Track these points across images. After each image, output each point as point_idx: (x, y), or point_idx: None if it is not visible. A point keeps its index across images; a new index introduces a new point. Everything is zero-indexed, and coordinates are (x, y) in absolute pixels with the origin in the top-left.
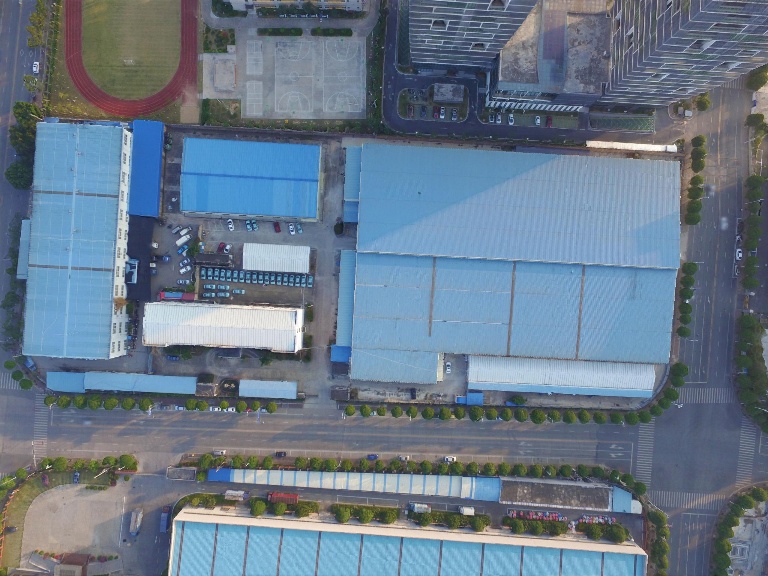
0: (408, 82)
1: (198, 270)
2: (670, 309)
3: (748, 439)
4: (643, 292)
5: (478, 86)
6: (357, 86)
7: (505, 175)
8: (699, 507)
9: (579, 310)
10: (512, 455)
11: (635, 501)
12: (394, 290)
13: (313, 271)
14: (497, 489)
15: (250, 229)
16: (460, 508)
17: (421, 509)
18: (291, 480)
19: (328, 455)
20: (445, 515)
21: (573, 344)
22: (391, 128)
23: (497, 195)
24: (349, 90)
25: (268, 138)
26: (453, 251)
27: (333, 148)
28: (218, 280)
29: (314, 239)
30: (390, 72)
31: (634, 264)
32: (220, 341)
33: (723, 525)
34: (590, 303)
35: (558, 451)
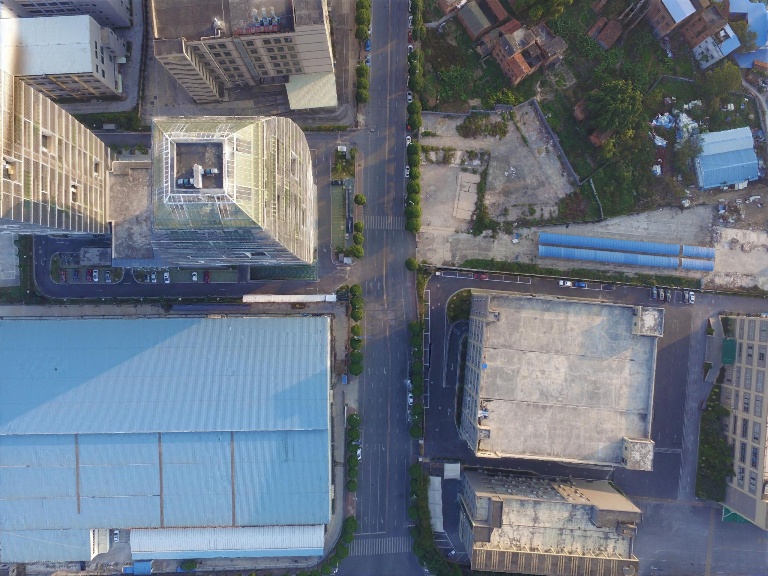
0: (60, 246)
1: None
2: (325, 469)
3: None
4: (296, 454)
5: None
6: (9, 252)
7: (145, 344)
8: None
9: (231, 476)
10: None
11: None
12: (37, 469)
13: None
14: None
15: None
16: None
17: None
18: None
19: None
20: None
21: (228, 511)
22: (45, 294)
23: (137, 366)
24: (1, 257)
25: None
26: (91, 428)
27: None
28: None
29: None
30: (40, 237)
31: (280, 428)
32: None
33: None
34: (242, 469)
35: None
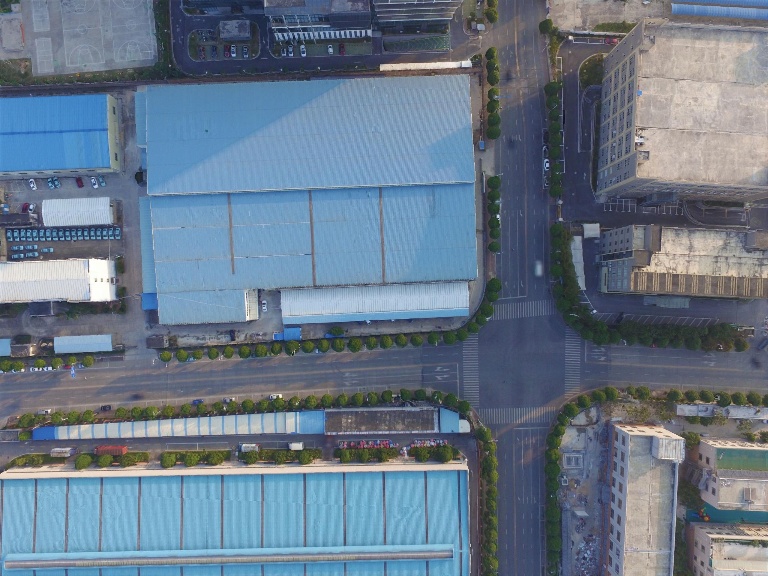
0: (196, 23)
1: (4, 232)
2: (472, 223)
3: (573, 349)
4: (443, 209)
5: (267, 21)
6: (147, 33)
7: (292, 105)
8: (530, 421)
9: (380, 233)
10: (338, 387)
11: (463, 420)
12: (192, 231)
13: (120, 223)
14: (321, 421)
15: (52, 187)
16: (289, 444)
17: (248, 448)
18: (116, 432)
19: (154, 404)
20: (274, 452)
21: (379, 268)
22: (184, 72)
23: (285, 125)
24: (139, 38)
25: (62, 94)
26: (244, 185)
27: (129, 98)
28: (26, 241)
29: (118, 191)
30: (177, 15)
31: (428, 181)
32: (15, 296)
33: (550, 435)
34: (391, 225)
35: (383, 379)
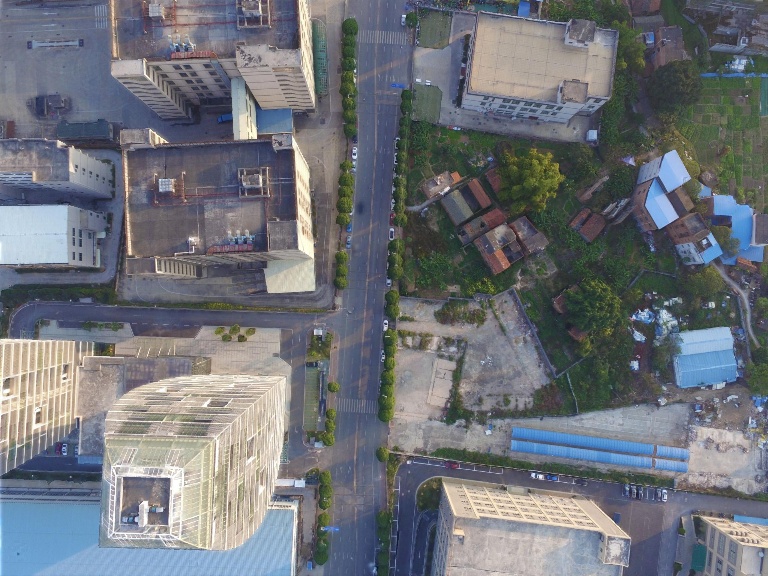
0: None
1: None
2: None
3: None
4: None
5: None
6: None
7: None
8: None
9: None
10: None
11: None
12: None
13: None
14: None
15: None
16: None
17: None
18: None
19: None
20: None
21: None
22: None
23: (100, 553)
24: None
25: None
26: None
27: None
28: None
29: None
30: None
31: None
32: None
33: None
34: None
35: None
